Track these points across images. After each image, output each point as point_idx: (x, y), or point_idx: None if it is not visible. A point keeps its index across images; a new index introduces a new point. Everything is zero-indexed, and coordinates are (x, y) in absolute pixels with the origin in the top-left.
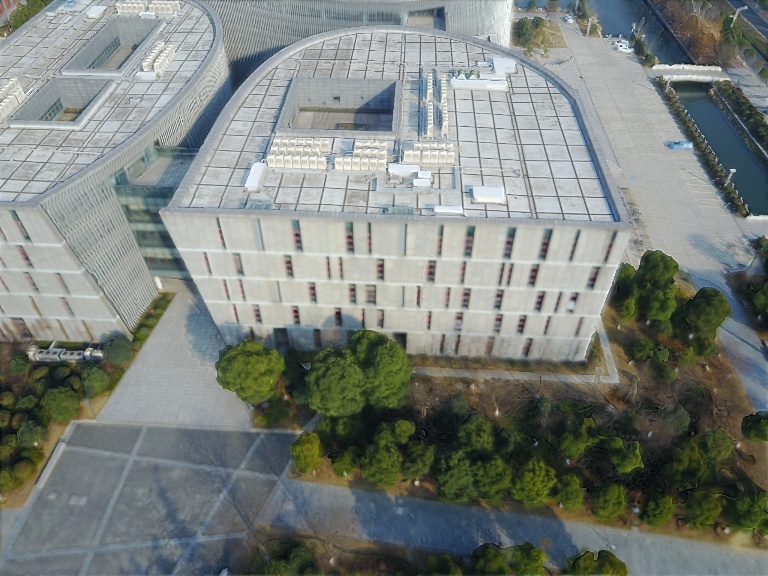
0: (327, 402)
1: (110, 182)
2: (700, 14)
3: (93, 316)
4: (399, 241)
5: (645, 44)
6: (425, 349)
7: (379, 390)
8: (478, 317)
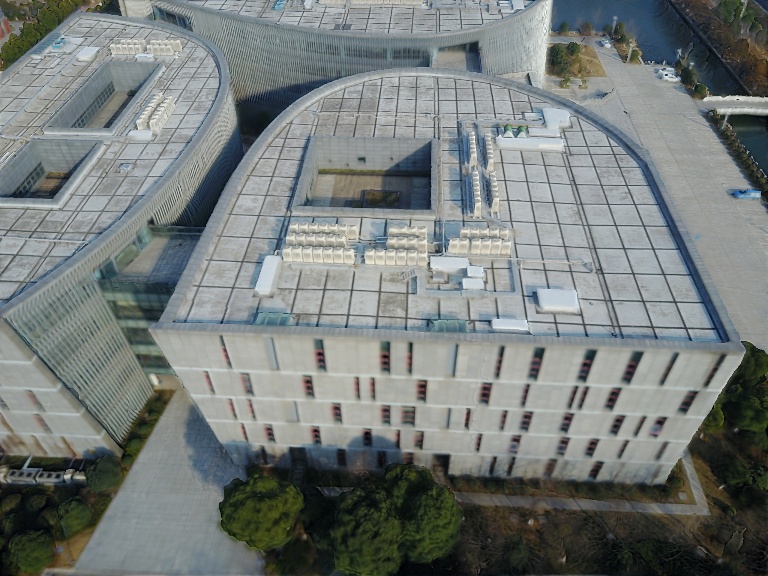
0: (358, 567)
1: (93, 277)
2: (749, 36)
3: (74, 432)
4: (447, 362)
5: (694, 73)
6: (472, 470)
7: (422, 545)
8: (539, 440)
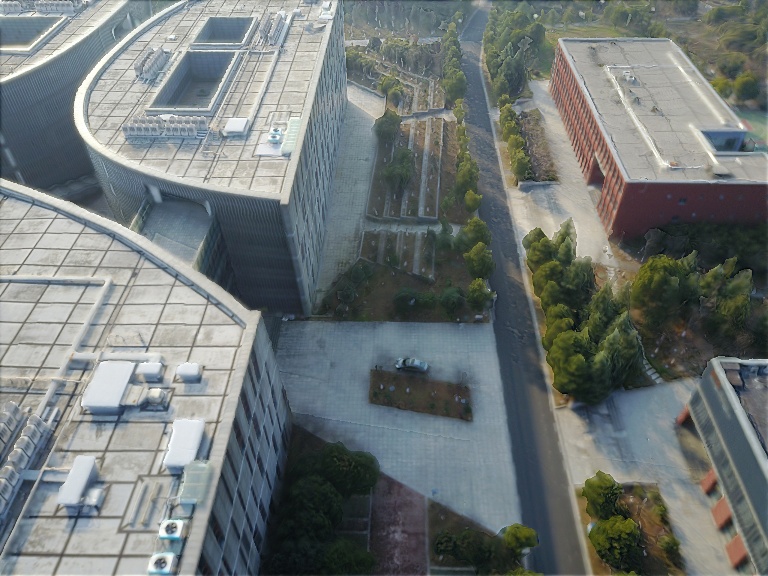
0: None
1: None
2: None
3: None
4: None
5: None
6: None
7: None
8: None
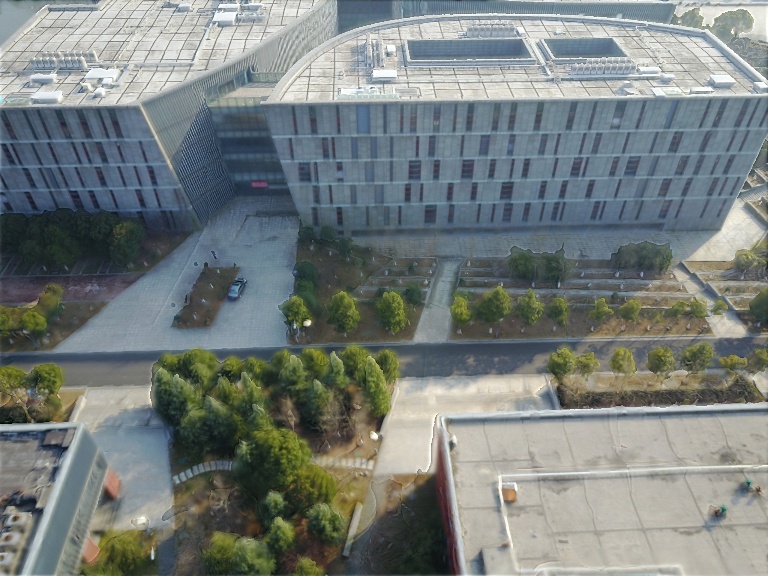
0: None
1: None
2: None
3: None
4: None
5: None
6: None
7: None
8: None
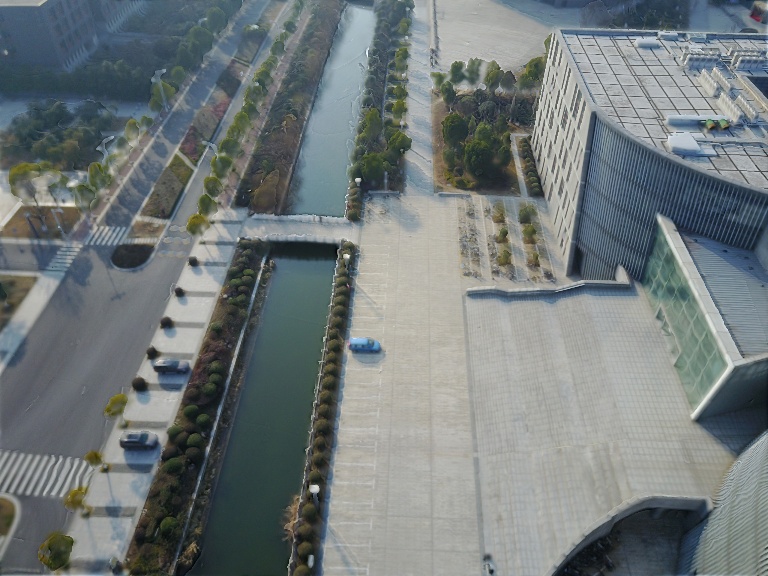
0: None
1: None
2: None
3: None
4: None
5: None
6: None
7: None
8: None
